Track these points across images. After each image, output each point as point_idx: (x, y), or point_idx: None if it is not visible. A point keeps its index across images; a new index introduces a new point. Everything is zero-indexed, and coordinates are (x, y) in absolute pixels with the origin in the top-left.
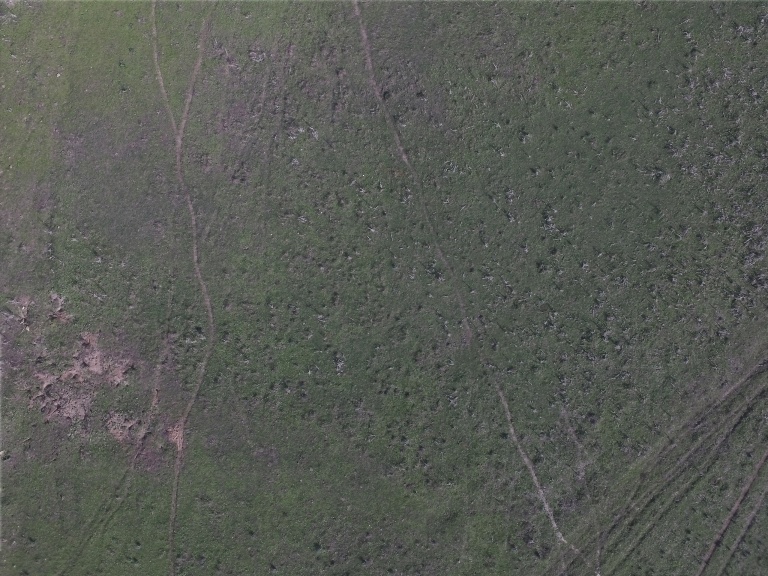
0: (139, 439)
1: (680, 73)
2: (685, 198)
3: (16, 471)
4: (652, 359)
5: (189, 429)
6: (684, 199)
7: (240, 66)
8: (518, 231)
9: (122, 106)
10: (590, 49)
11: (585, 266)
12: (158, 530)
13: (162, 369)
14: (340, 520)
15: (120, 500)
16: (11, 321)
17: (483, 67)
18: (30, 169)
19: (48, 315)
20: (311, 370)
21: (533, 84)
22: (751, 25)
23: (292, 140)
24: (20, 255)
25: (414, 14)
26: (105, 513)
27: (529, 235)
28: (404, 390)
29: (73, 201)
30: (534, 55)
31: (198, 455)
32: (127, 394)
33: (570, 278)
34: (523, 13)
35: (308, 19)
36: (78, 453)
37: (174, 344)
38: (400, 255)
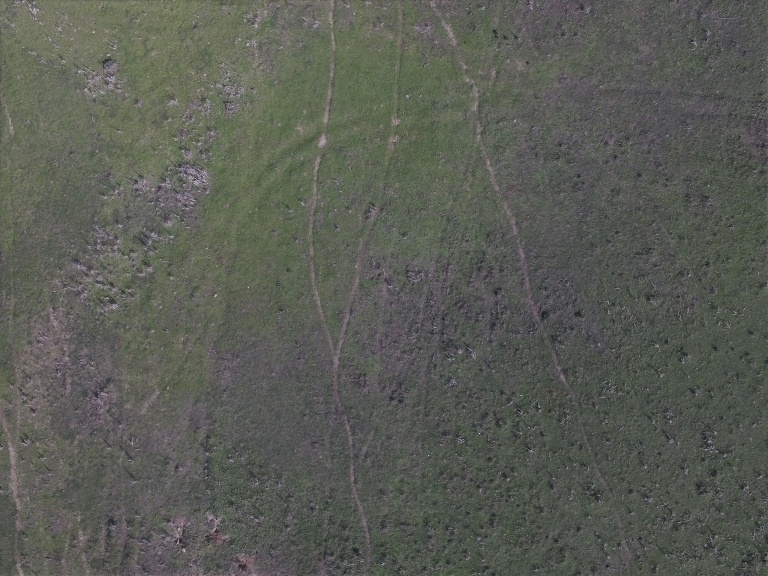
0: None
1: None
2: None
3: None
4: None
5: None
6: None
7: (398, 286)
8: (677, 452)
9: (279, 326)
10: (749, 269)
11: (746, 488)
12: None
13: None
14: None
15: None
16: (167, 543)
17: (641, 286)
18: (187, 389)
19: (204, 536)
20: None
21: (692, 304)
22: None
23: (450, 361)
24: (176, 476)
25: (572, 233)
26: None
27: (688, 456)
28: None
29: (229, 421)
30: (692, 274)
31: None
32: None
33: (730, 500)
34: (681, 232)
35: (466, 239)
36: None
37: (332, 566)
38: (558, 476)
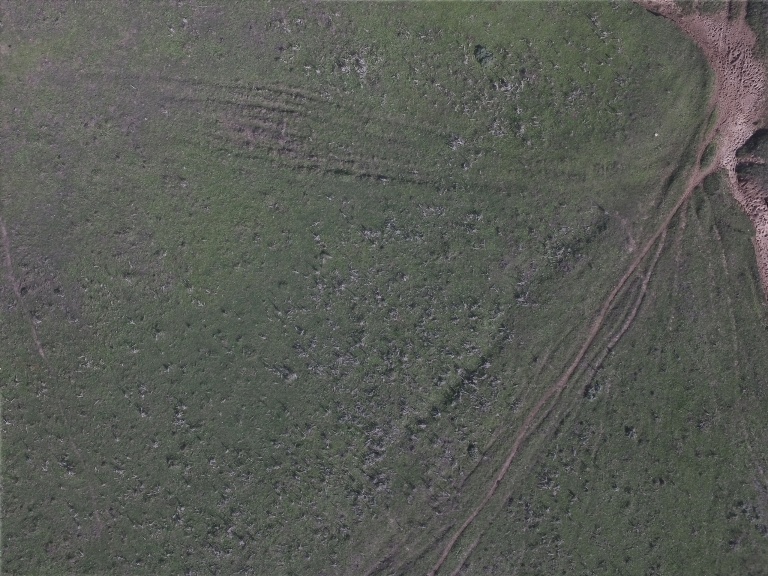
0: None
1: (309, 274)
2: (312, 397)
3: None
4: (275, 555)
5: None
6: (310, 398)
7: None
8: (150, 426)
9: None
10: (223, 249)
11: (212, 462)
12: None
13: None
14: None
15: None
16: None
17: (119, 265)
18: None
19: None
20: None
21: (167, 282)
22: (378, 229)
23: None
24: None
25: (53, 212)
26: None
27: (160, 430)
28: None
29: None
30: (169, 254)
31: None
32: None
33: (198, 473)
34: (159, 213)
35: None
36: None
37: None
38: (35, 447)
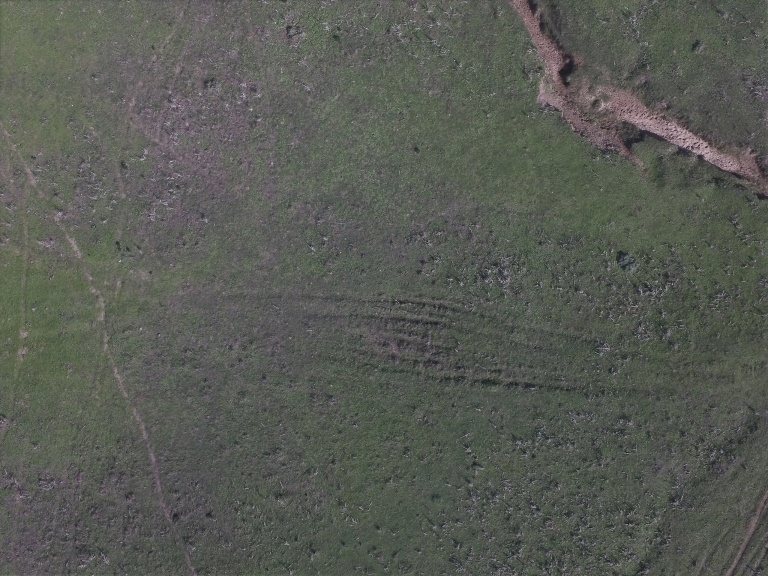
0: None
1: (462, 486)
2: None
3: None
4: None
5: None
6: None
7: (30, 495)
8: None
9: None
10: (374, 465)
11: None
12: None
13: None
14: None
15: None
16: None
17: (270, 485)
18: None
19: None
20: None
21: (319, 501)
22: (529, 438)
23: (83, 567)
24: None
25: (201, 436)
26: None
27: None
28: None
29: None
30: (320, 472)
31: None
32: None
33: None
34: (307, 431)
35: (96, 446)
36: None
37: None
38: None
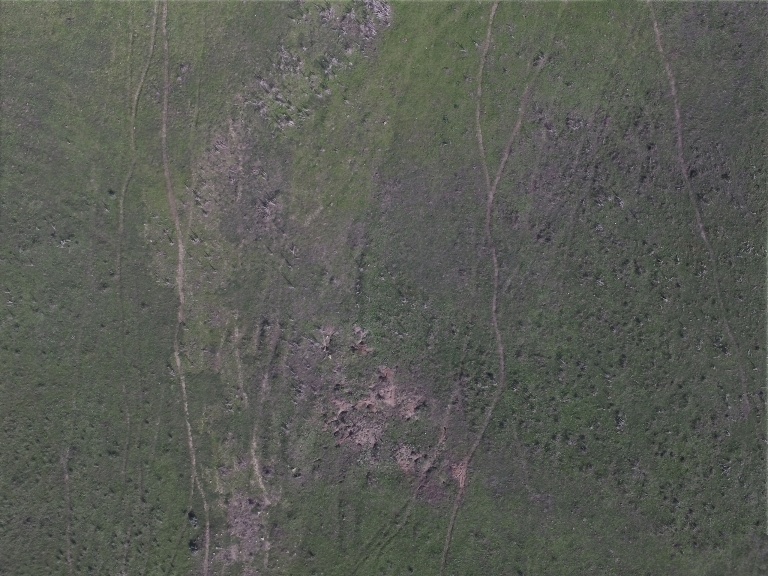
0: (424, 472)
1: None
2: None
3: (304, 488)
4: None
5: (473, 468)
6: None
7: (557, 132)
8: None
9: (441, 158)
10: None
11: None
12: (432, 559)
13: (452, 409)
14: (607, 571)
15: (399, 527)
16: (316, 348)
17: None
18: (349, 208)
19: (350, 346)
20: (593, 426)
21: None
22: None
23: (599, 207)
24: (330, 287)
25: (728, 99)
26: (383, 537)
27: None
28: (680, 455)
29: (385, 242)
30: None
31: (478, 493)
32: (416, 428)
33: None
34: None
35: (626, 94)
36: (366, 478)
37: (466, 387)
38: (689, 326)
